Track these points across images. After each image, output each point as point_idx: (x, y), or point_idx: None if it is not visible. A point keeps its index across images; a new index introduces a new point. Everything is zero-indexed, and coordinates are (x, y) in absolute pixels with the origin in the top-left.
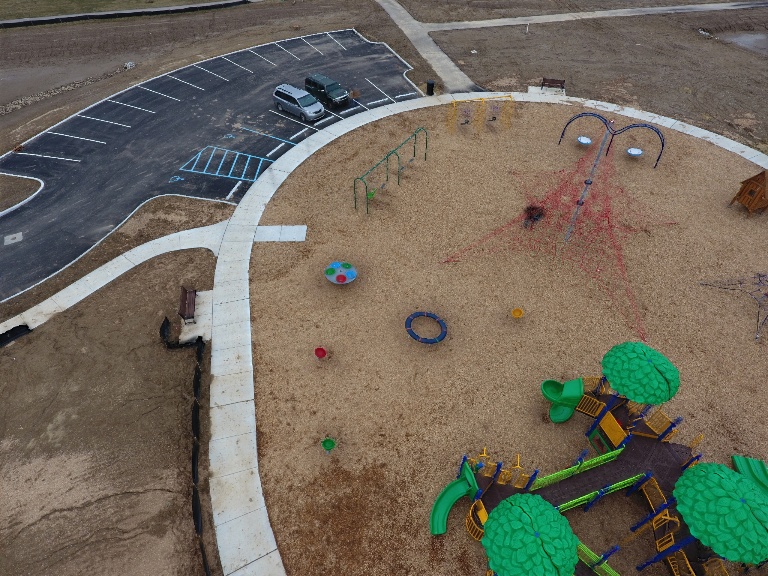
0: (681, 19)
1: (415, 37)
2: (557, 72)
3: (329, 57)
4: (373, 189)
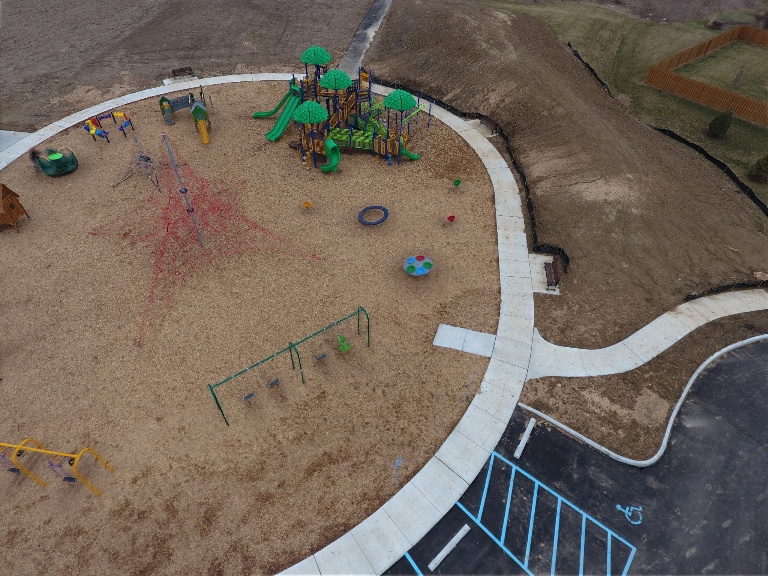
0: None
1: None
2: None
3: None
4: (342, 338)
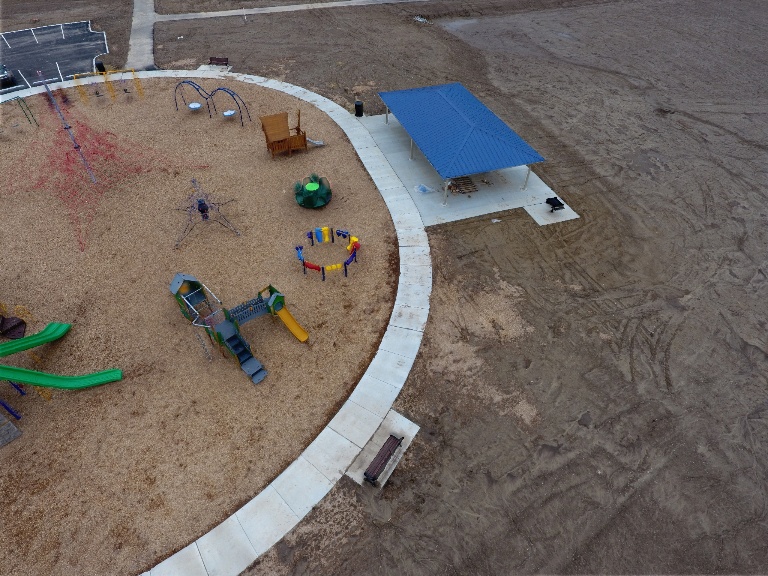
0: (406, 7)
1: (138, 26)
2: (239, 53)
3: (41, 45)
4: None
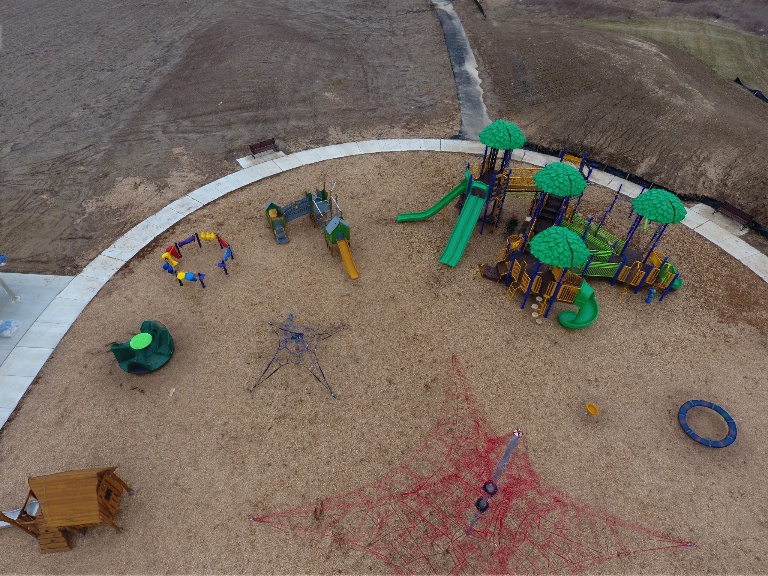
0: None
1: None
2: None
3: None
4: None
